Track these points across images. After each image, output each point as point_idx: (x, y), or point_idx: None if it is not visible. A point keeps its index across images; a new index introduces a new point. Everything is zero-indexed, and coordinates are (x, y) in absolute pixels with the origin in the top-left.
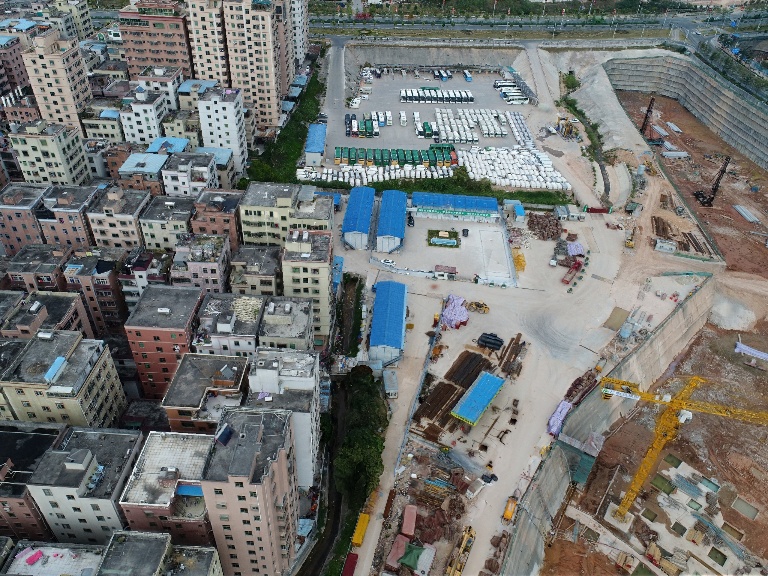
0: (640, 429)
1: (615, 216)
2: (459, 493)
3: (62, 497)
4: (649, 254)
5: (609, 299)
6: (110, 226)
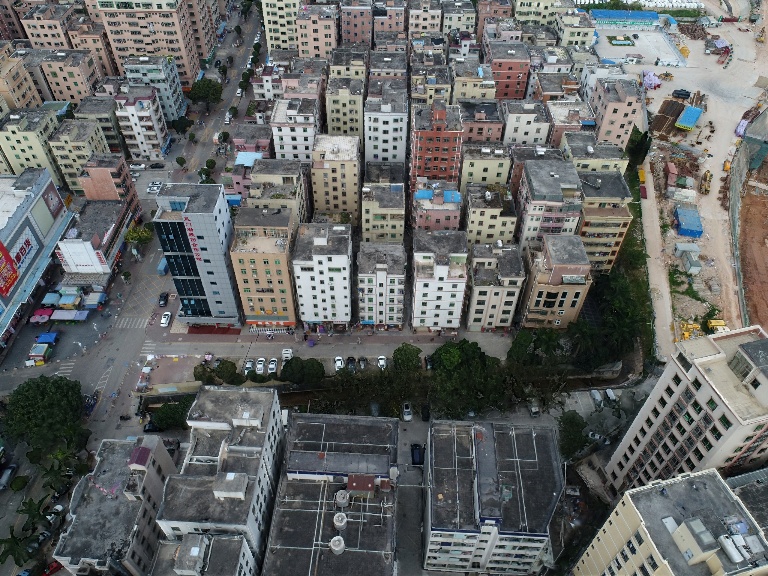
0: None
1: (743, 24)
2: (693, 161)
3: (524, 123)
4: None
5: (754, 71)
6: (423, 20)
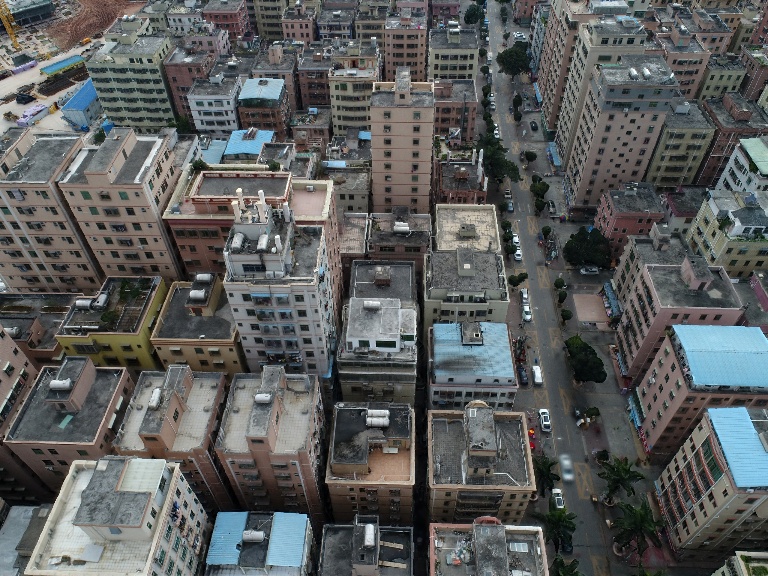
0: None
1: None
2: None
3: None
4: None
5: None
6: None
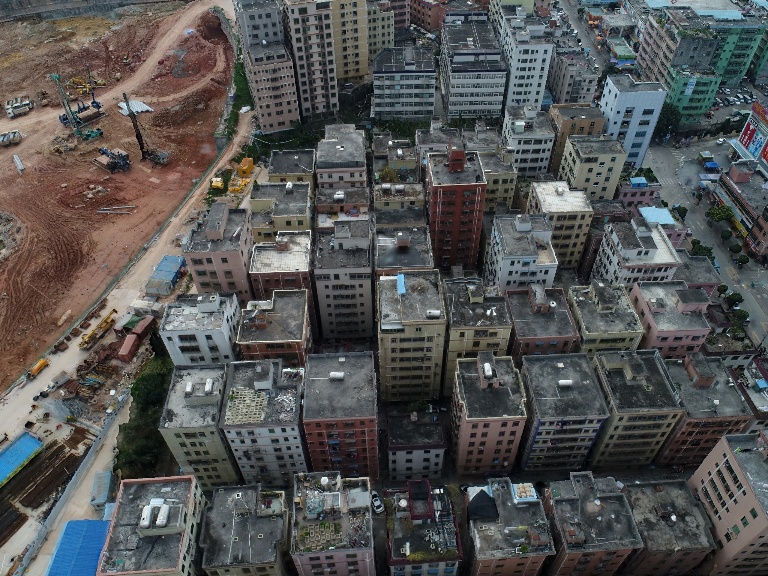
0: None
1: None
2: None
3: None
4: None
5: None
6: None
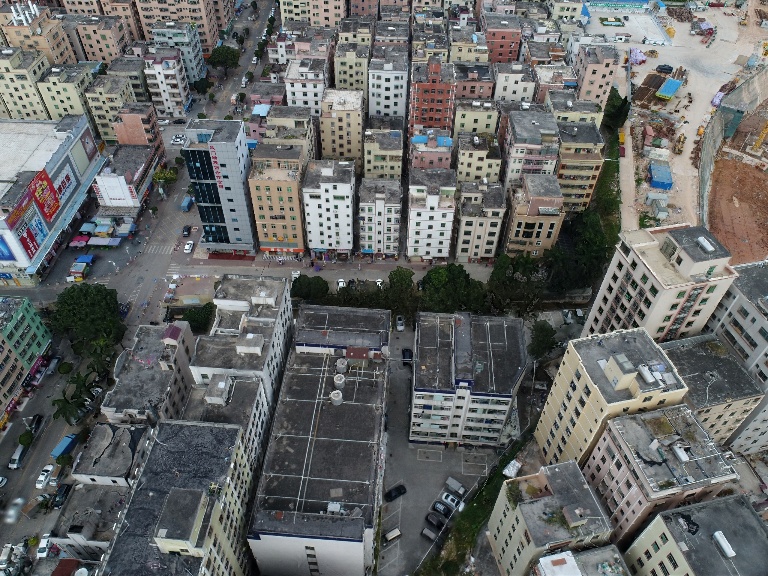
0: (760, 118)
1: (729, 9)
2: (670, 126)
3: (512, 82)
4: (757, 29)
5: (735, 51)
6: None
